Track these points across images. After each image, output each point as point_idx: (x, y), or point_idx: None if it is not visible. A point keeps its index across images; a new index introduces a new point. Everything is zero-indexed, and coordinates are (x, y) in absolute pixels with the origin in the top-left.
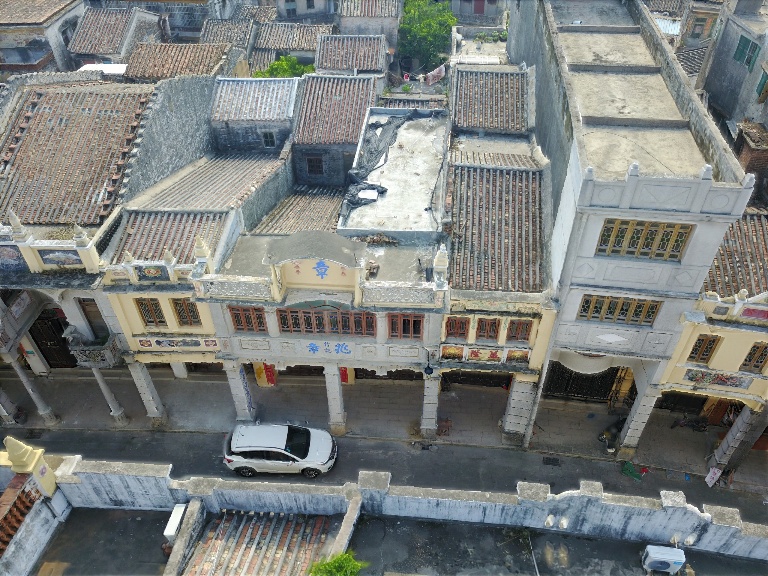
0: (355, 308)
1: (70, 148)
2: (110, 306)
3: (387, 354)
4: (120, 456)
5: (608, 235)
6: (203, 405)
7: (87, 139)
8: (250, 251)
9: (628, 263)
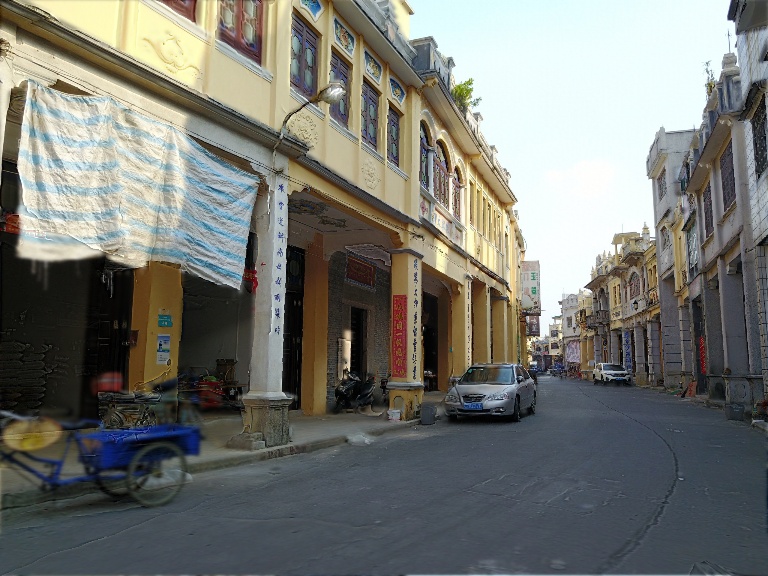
0: None
1: None
2: (609, 293)
3: None
4: None
5: (661, 190)
6: None
7: None
8: None
9: (661, 201)
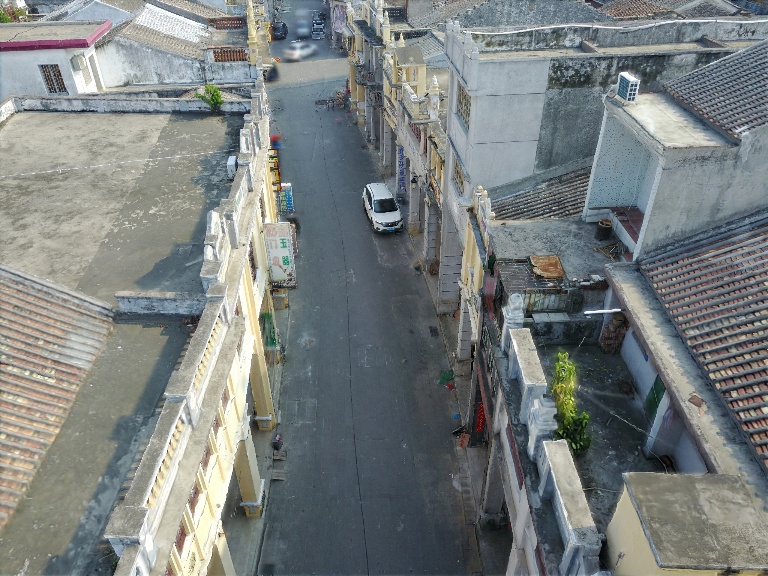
0: (400, 100)
1: (467, 5)
2: None
3: (421, 167)
4: (362, 171)
5: None
6: (407, 184)
7: (477, 4)
8: (435, 72)
9: None
